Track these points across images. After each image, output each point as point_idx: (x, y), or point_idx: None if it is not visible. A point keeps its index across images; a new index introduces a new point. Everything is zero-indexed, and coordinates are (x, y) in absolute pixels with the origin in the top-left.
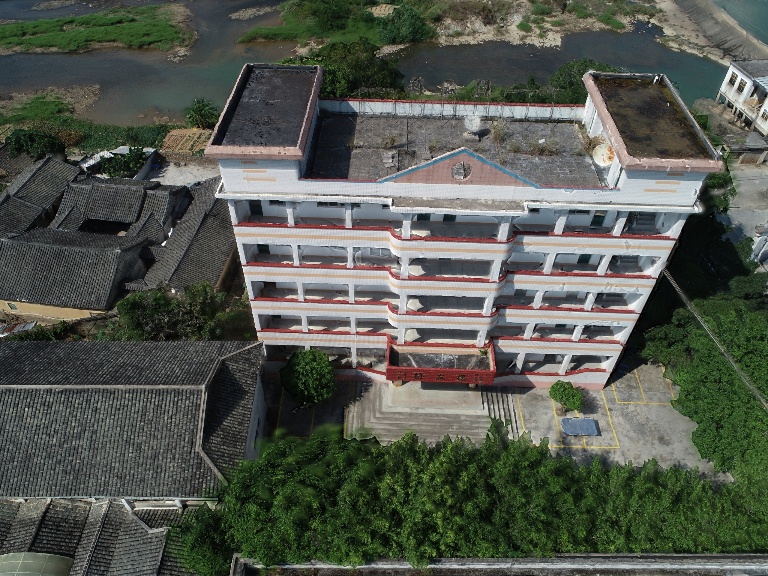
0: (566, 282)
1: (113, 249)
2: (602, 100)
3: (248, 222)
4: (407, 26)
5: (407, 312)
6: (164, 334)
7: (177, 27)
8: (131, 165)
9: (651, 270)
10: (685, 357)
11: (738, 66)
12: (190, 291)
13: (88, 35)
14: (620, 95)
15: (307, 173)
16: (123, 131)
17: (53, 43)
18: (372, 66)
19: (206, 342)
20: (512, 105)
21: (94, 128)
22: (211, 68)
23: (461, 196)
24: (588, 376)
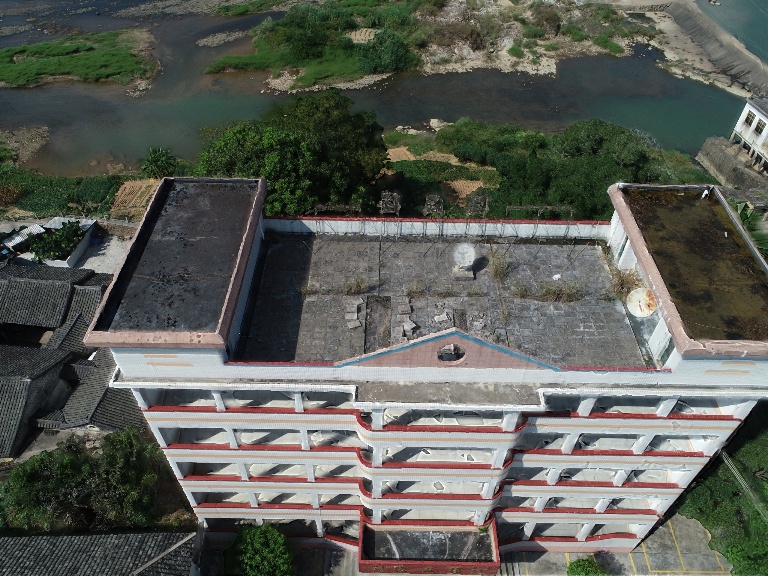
0: (591, 460)
1: (21, 378)
2: (639, 233)
3: (162, 405)
4: (389, 54)
5: (383, 496)
6: (71, 514)
7: (139, 56)
8: (63, 245)
9: (703, 444)
10: (737, 525)
11: (756, 105)
12: (111, 443)
13: (39, 67)
14: (660, 219)
15: (241, 340)
16: (70, 184)
17: (0, 77)
18: (345, 125)
19: (121, 537)
20: (516, 223)
21: (37, 181)
22: (174, 104)
23: (451, 380)
24: (613, 541)
